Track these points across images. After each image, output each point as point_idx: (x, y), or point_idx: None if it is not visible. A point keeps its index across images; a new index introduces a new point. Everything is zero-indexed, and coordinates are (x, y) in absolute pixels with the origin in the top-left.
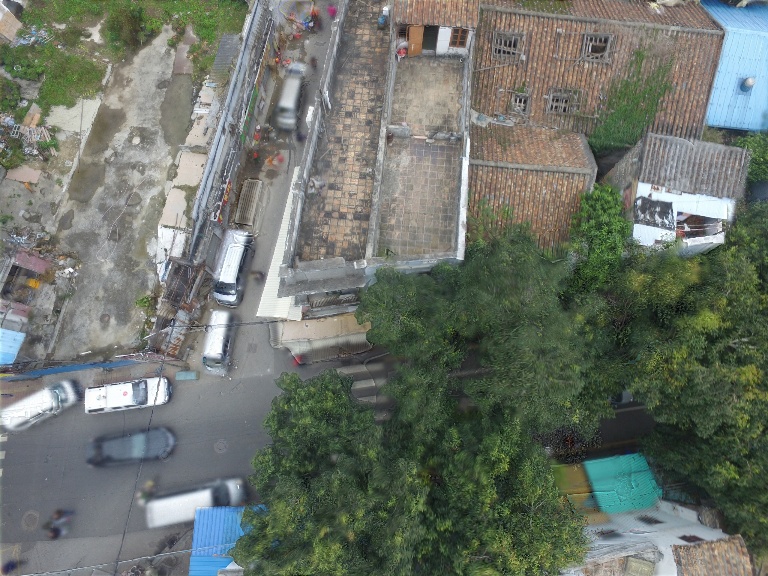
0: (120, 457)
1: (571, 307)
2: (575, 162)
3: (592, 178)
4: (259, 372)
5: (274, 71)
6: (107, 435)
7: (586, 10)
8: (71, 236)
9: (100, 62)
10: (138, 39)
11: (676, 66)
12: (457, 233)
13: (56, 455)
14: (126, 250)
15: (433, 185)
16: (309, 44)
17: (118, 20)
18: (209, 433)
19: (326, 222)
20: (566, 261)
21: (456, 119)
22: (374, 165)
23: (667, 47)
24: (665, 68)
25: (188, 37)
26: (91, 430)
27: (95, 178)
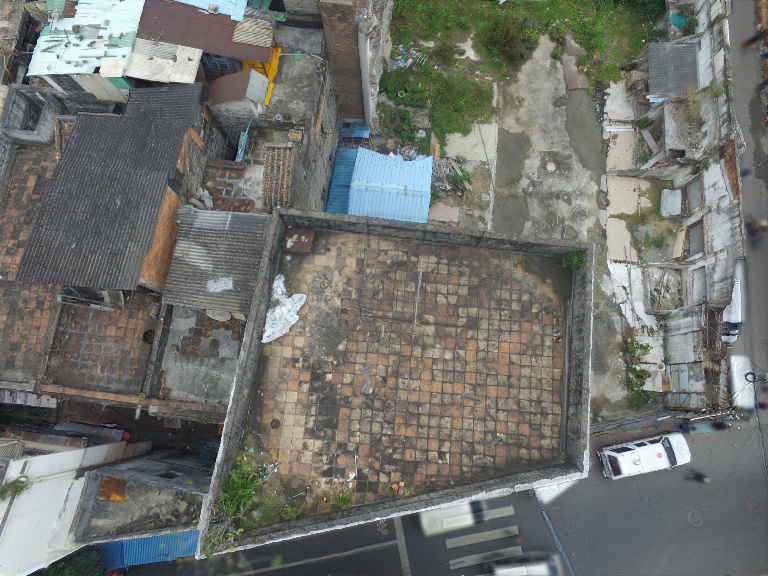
0: (646, 524)
1: None
2: None
3: None
4: (767, 418)
5: None
6: (623, 500)
7: None
8: None
9: (484, 81)
10: (522, 53)
11: None
12: None
13: (575, 526)
14: None
15: None
16: None
17: (508, 33)
18: (735, 491)
19: None
20: None
21: None
22: None
23: None
24: None
25: (571, 47)
26: (603, 496)
27: (518, 212)
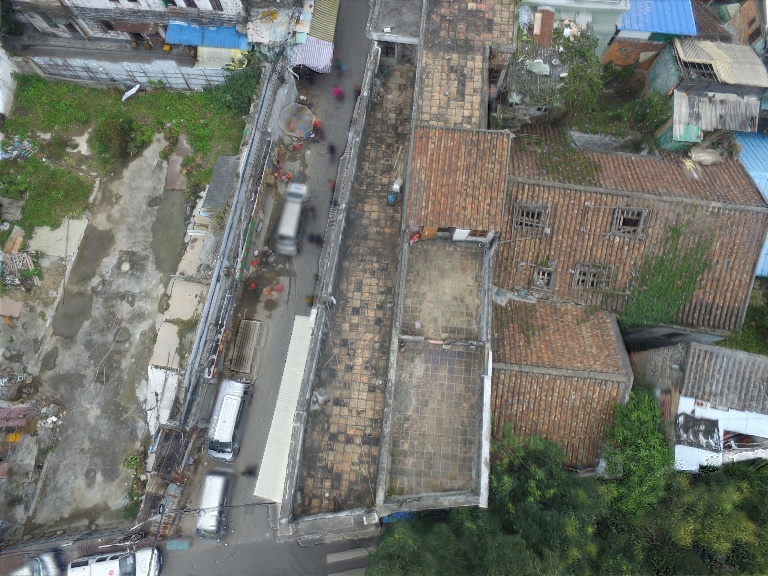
0: None
1: (605, 536)
2: (607, 362)
3: (627, 387)
4: (257, 536)
5: (273, 187)
6: None
7: (616, 176)
8: (55, 378)
9: (87, 176)
10: (128, 151)
11: (717, 244)
12: (479, 470)
13: None
14: (114, 394)
15: (450, 400)
16: (310, 155)
17: (106, 134)
18: None
19: (331, 447)
20: (598, 475)
21: (475, 318)
22: (384, 375)
23: (707, 224)
24: (705, 246)
25: (181, 147)
26: None
27: (81, 310)
